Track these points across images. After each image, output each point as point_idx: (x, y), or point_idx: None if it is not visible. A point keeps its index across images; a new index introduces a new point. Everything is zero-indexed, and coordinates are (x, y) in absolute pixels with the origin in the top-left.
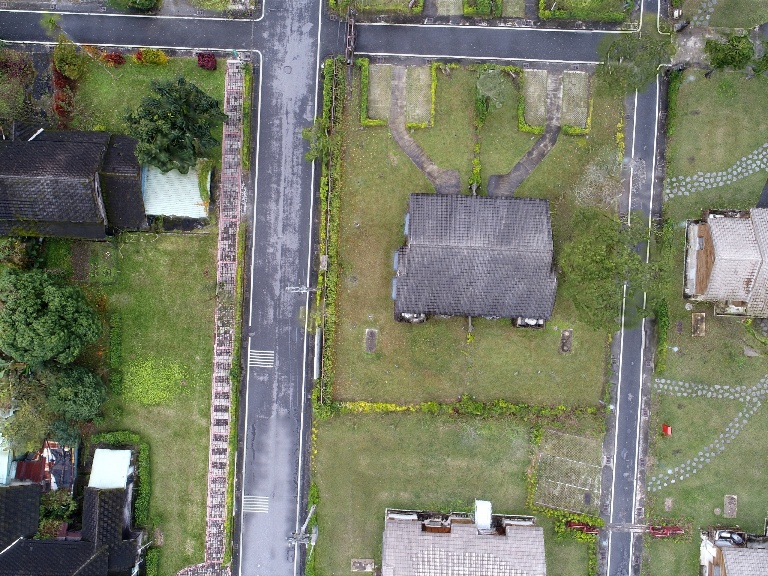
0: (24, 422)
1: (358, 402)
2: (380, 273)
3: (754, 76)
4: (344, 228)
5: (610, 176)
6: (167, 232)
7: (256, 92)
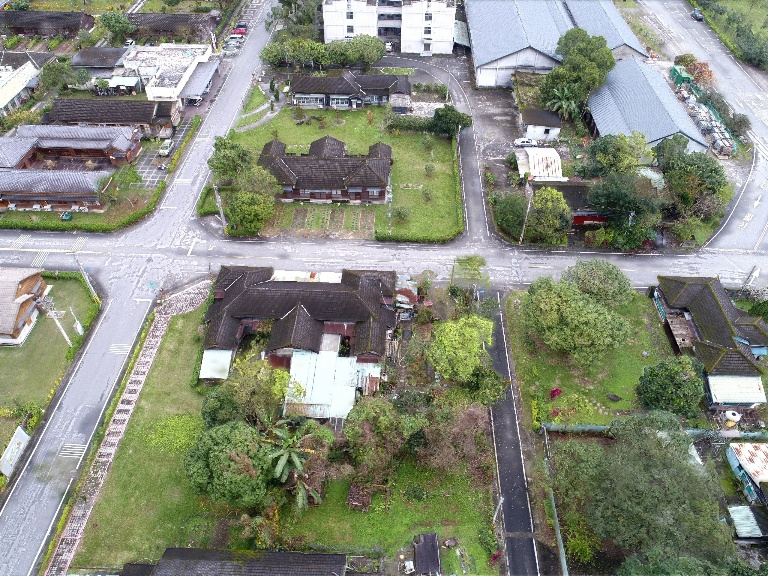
0: (251, 381)
1: (1, 416)
2: None
3: None
4: None
5: None
6: None
7: None
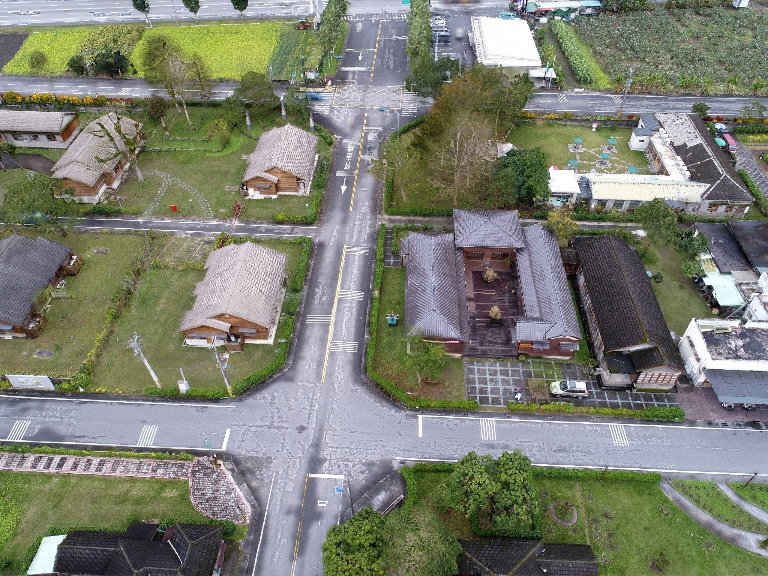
0: None
1: None
2: None
3: None
4: None
5: (3, 232)
6: None
7: None
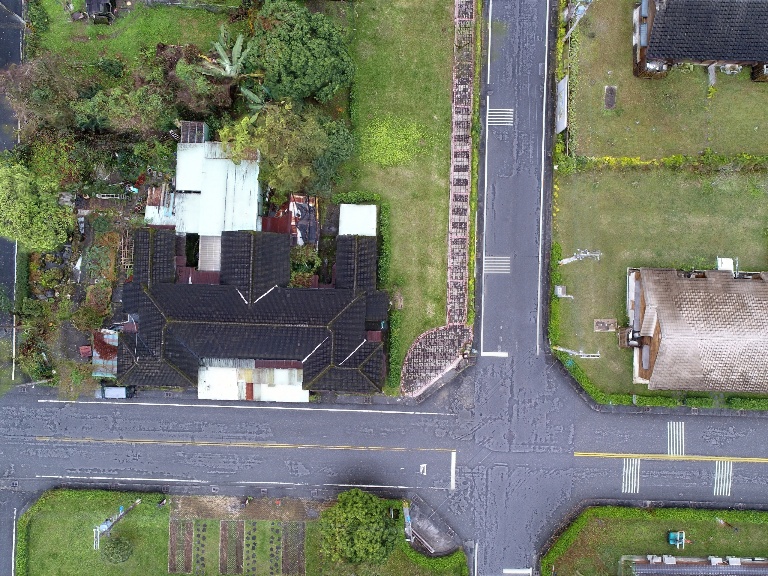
0: (289, 156)
1: (601, 157)
2: (618, 29)
3: None
4: None
5: None
6: None
7: None
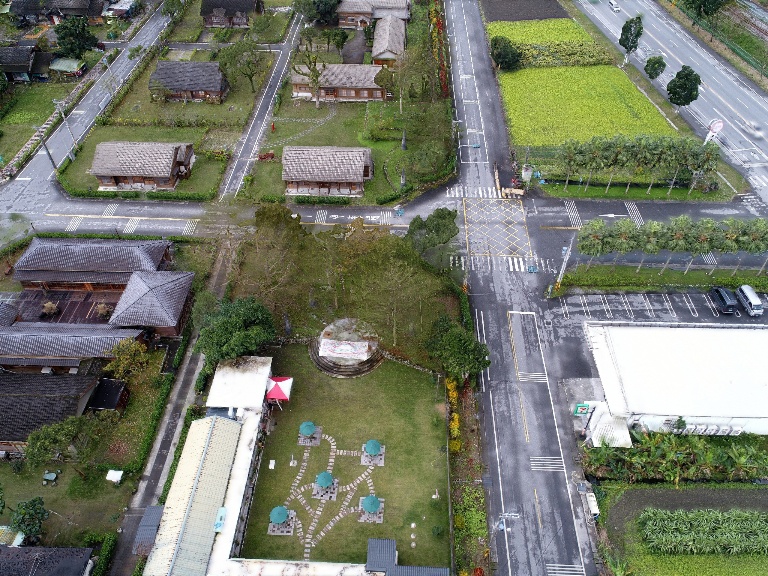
0: None
1: None
2: None
3: (328, 50)
4: (139, 82)
5: None
6: (56, 83)
7: (118, 55)
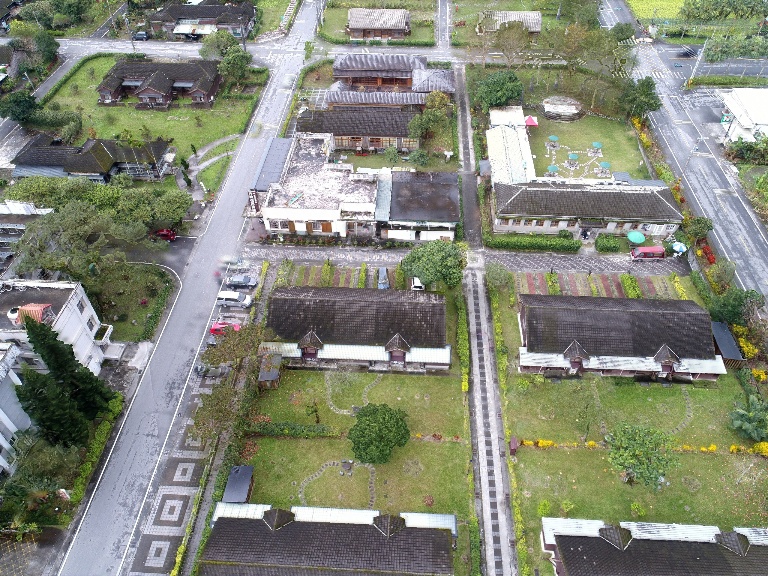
0: None
1: None
2: None
3: None
4: None
5: None
6: None
7: None
